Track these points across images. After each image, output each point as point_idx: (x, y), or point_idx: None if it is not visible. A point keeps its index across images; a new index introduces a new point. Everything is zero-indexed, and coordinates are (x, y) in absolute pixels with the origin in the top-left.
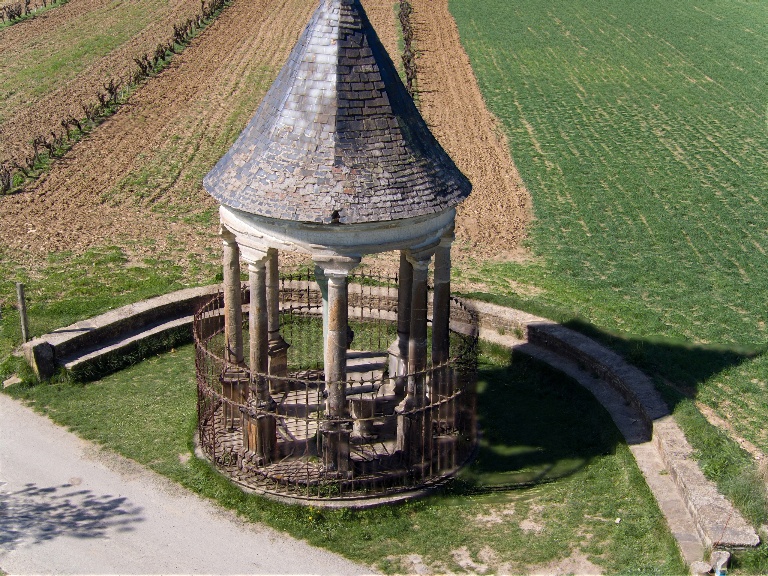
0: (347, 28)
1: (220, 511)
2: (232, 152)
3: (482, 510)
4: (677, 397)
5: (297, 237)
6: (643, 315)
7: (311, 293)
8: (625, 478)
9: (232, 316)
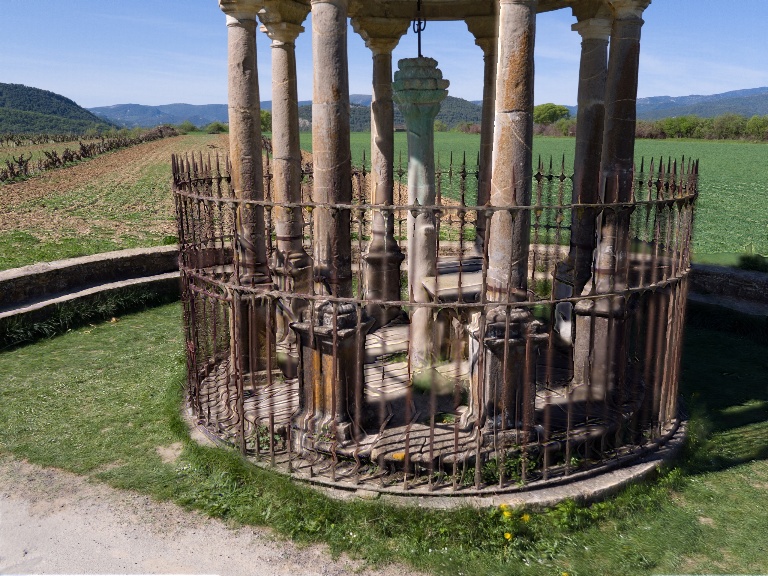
0: None
1: (287, 553)
2: None
3: None
4: None
5: None
6: None
7: None
8: None
9: (247, 171)
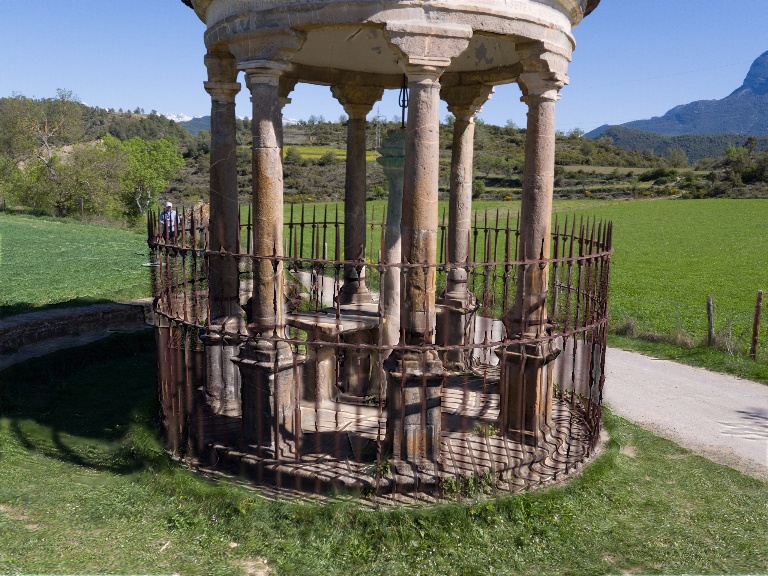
0: None
1: None
2: None
3: None
4: None
5: None
6: None
7: None
8: None
9: None
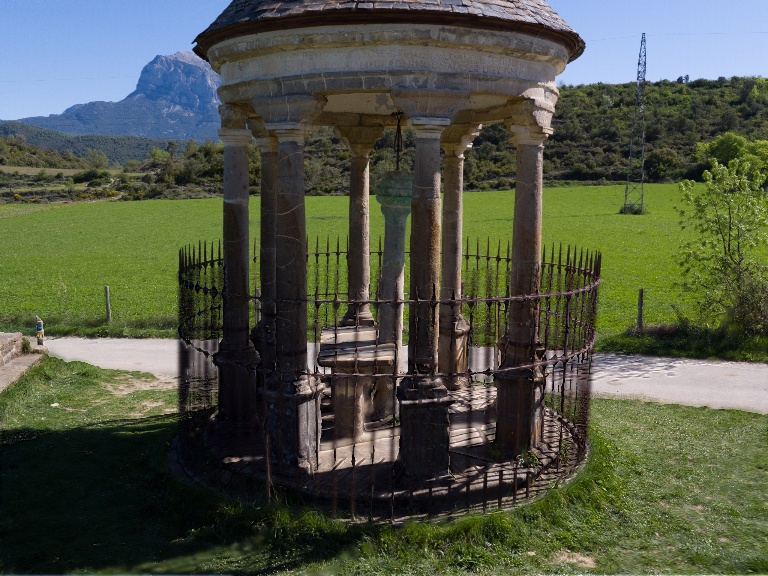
0: None
1: None
2: None
3: None
4: None
5: None
6: None
7: None
8: (1, 428)
9: None
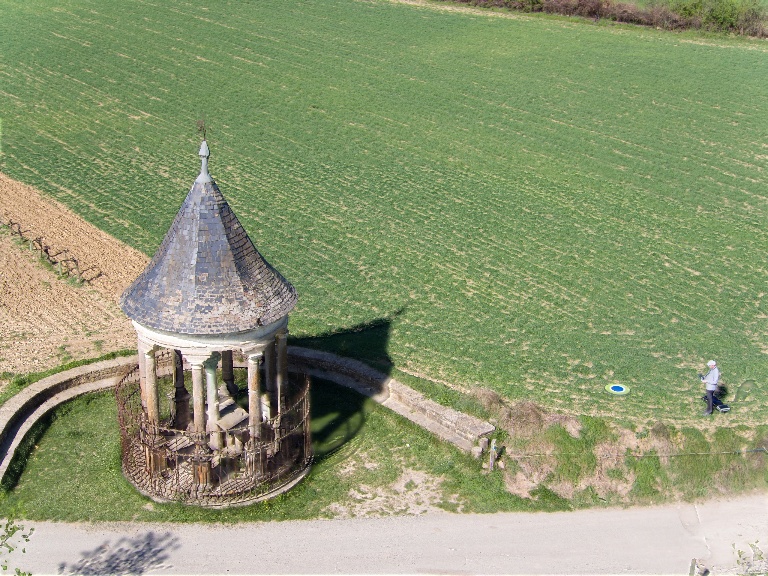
0: (221, 204)
1: (211, 526)
2: (156, 297)
3: (340, 467)
4: (388, 368)
5: (232, 341)
6: (314, 323)
7: (95, 373)
8: (390, 422)
9: (156, 403)
